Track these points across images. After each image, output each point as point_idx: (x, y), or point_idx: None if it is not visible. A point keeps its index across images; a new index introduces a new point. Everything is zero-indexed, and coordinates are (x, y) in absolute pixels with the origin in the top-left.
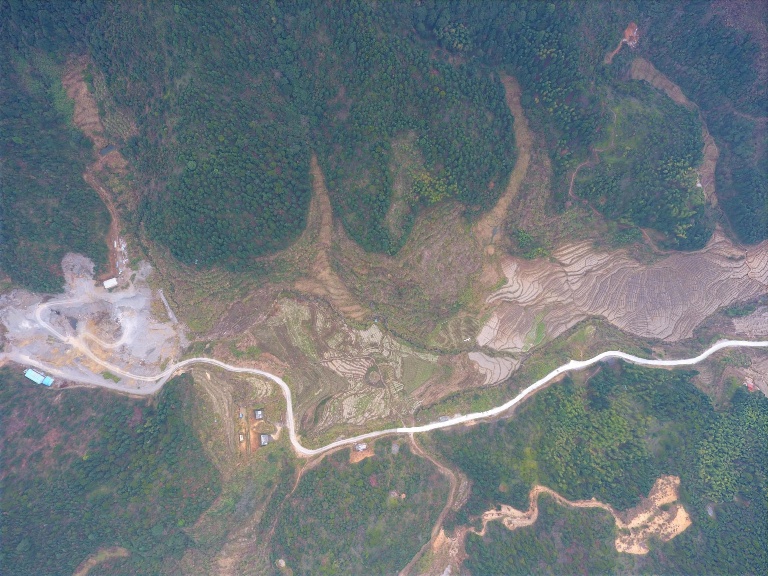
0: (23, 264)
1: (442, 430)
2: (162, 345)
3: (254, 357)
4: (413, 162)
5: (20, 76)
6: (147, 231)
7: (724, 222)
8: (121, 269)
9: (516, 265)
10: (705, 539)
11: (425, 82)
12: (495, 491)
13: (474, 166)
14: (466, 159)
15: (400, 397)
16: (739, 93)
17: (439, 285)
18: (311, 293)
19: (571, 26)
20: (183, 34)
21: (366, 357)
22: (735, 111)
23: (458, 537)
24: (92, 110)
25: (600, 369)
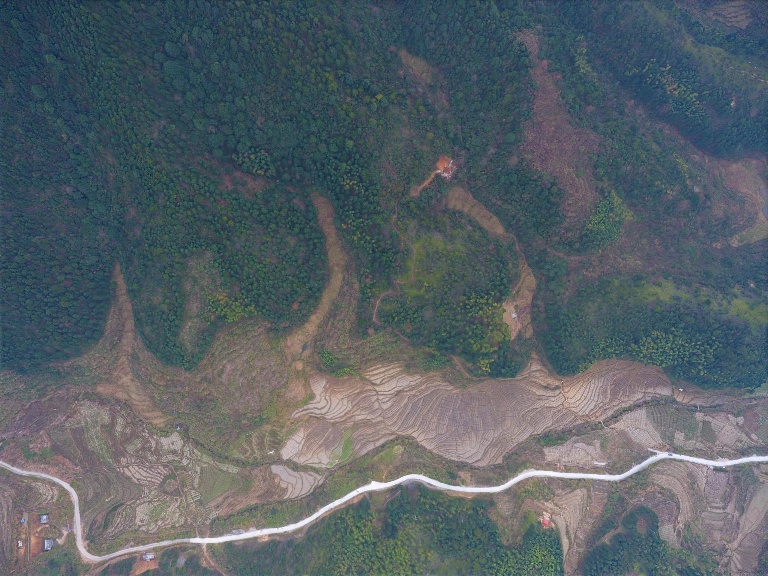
0: None
1: (234, 544)
2: None
3: (46, 460)
4: (212, 280)
5: None
6: None
7: (540, 352)
8: None
9: (325, 382)
10: None
11: (215, 209)
12: None
13: (271, 290)
14: (261, 284)
15: (196, 506)
16: (550, 233)
17: (239, 400)
18: (113, 397)
19: (371, 162)
20: None
21: (164, 464)
22: (548, 248)
23: None
24: None
25: (400, 492)
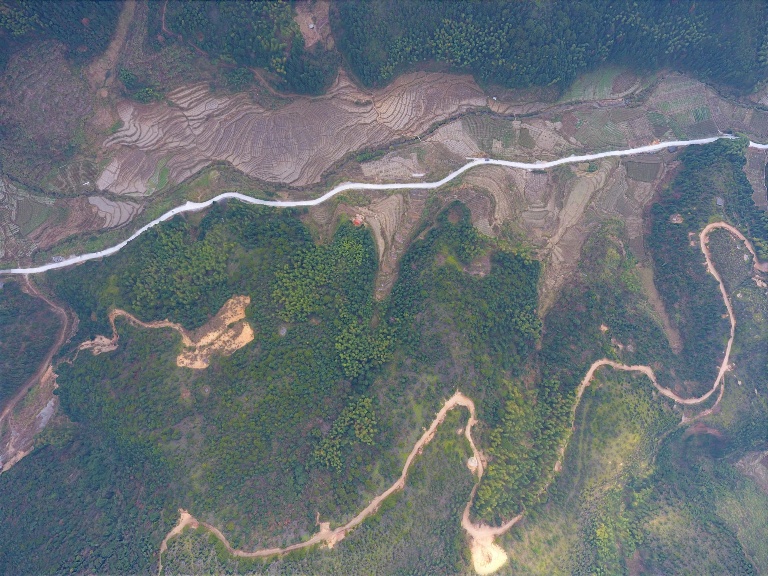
0: None
1: (53, 269)
2: None
3: None
4: None
5: None
6: None
7: (345, 65)
8: None
9: (132, 109)
10: (259, 351)
11: None
12: (87, 321)
13: None
14: None
15: (16, 239)
16: None
17: (42, 124)
18: None
19: None
20: None
21: None
22: None
23: None
24: None
25: None
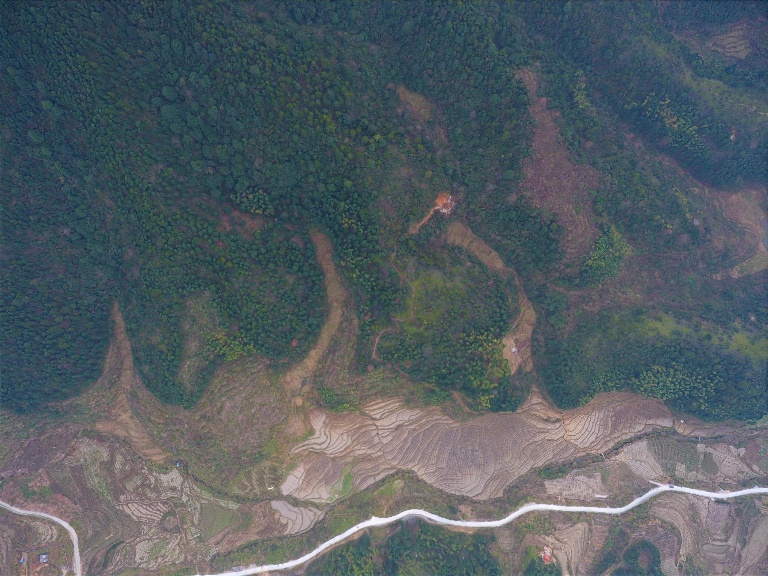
0: None
1: None
2: None
3: (45, 498)
4: (210, 319)
5: None
6: None
7: (540, 385)
8: None
9: (325, 417)
10: None
11: (213, 250)
12: None
13: (270, 329)
14: (260, 323)
15: (196, 543)
16: (549, 268)
17: (238, 437)
18: (112, 434)
19: (369, 201)
20: None
21: (164, 501)
22: (548, 283)
23: None
24: None
25: (400, 528)
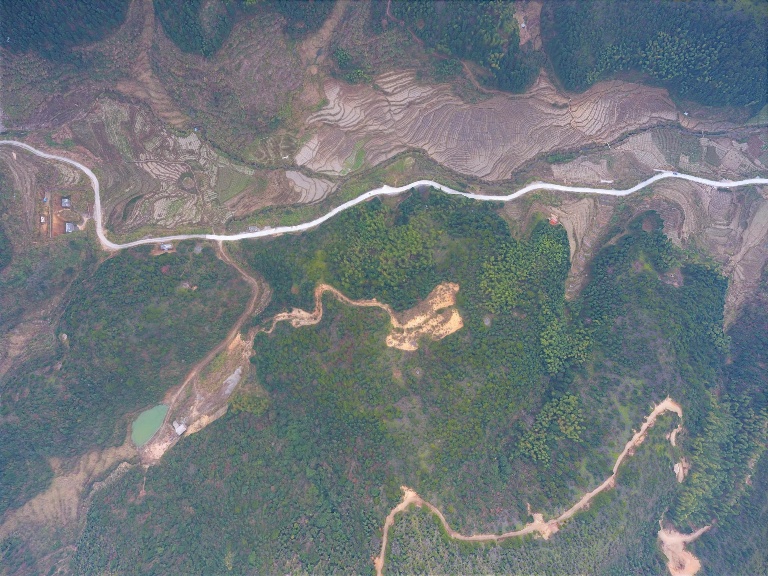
0: None
1: (249, 239)
2: None
3: (67, 148)
4: None
5: None
6: None
7: (548, 67)
8: None
9: (339, 88)
10: (471, 339)
11: None
12: (287, 293)
13: None
14: None
15: (213, 206)
16: None
17: (255, 95)
18: (132, 95)
19: None
20: None
21: (182, 163)
22: None
23: (252, 340)
24: None
25: None
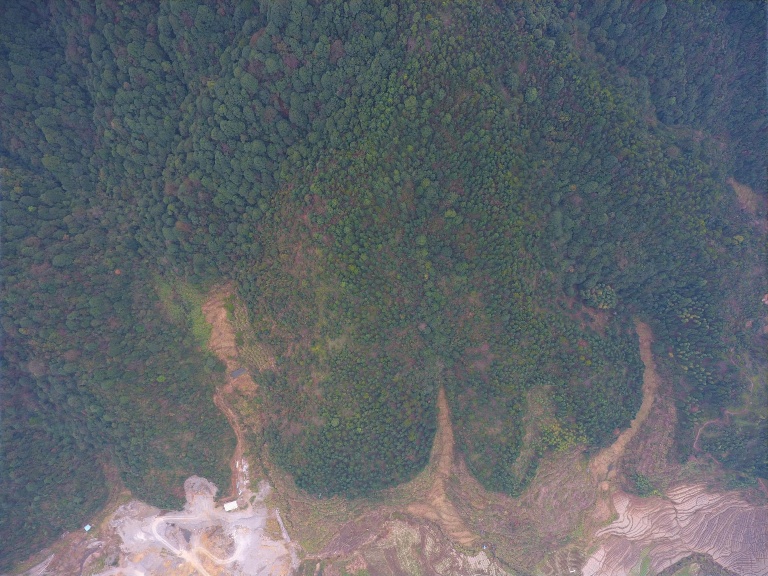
0: (149, 489)
1: None
2: (273, 563)
3: None
4: (544, 410)
5: (162, 301)
6: (272, 457)
7: None
8: (241, 490)
9: (628, 501)
10: None
11: (571, 348)
12: None
13: (606, 422)
14: (600, 417)
15: None
16: None
17: (553, 523)
18: (423, 517)
19: (719, 299)
20: (345, 306)
21: None
22: None
23: None
24: (228, 335)
25: None
